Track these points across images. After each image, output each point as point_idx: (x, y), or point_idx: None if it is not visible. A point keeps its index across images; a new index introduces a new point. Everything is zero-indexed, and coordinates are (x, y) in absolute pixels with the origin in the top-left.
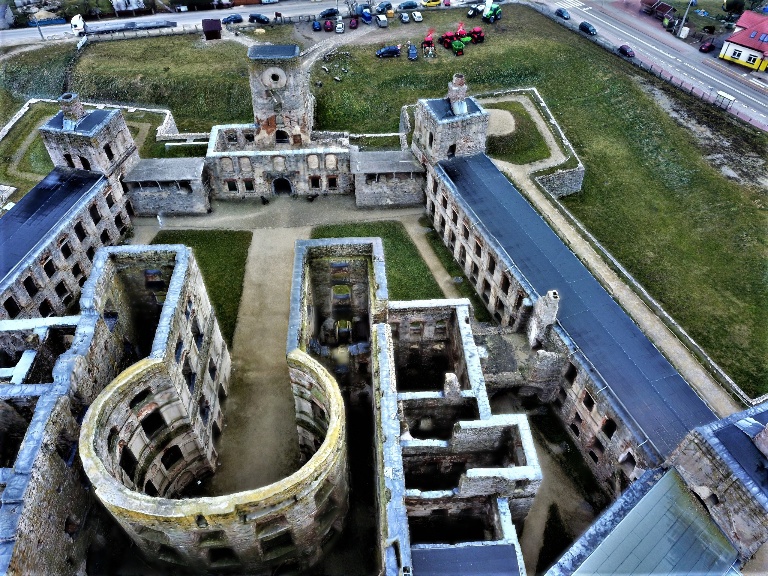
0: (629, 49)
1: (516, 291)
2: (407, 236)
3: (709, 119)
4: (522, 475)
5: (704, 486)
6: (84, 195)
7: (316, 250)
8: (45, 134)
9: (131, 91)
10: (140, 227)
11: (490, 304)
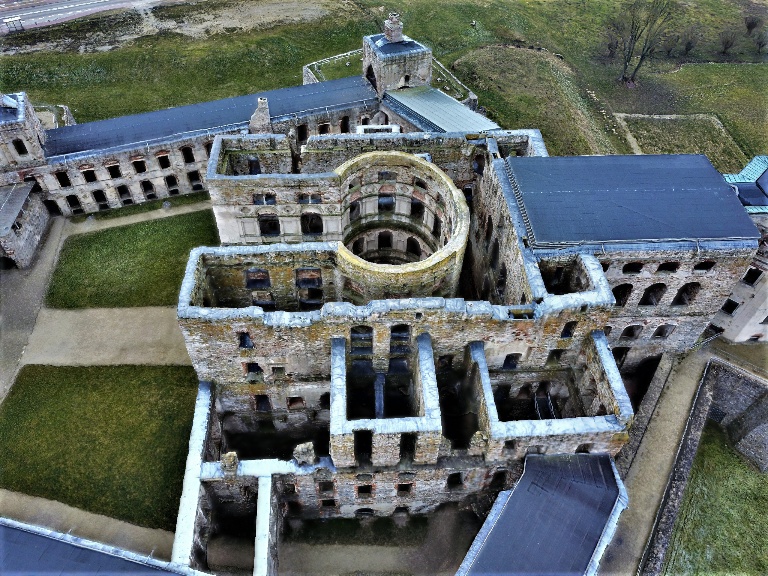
0: None
1: None
2: (94, 233)
3: (30, 39)
4: (398, 131)
5: (401, 79)
6: None
7: None
8: None
9: None
10: None
11: None
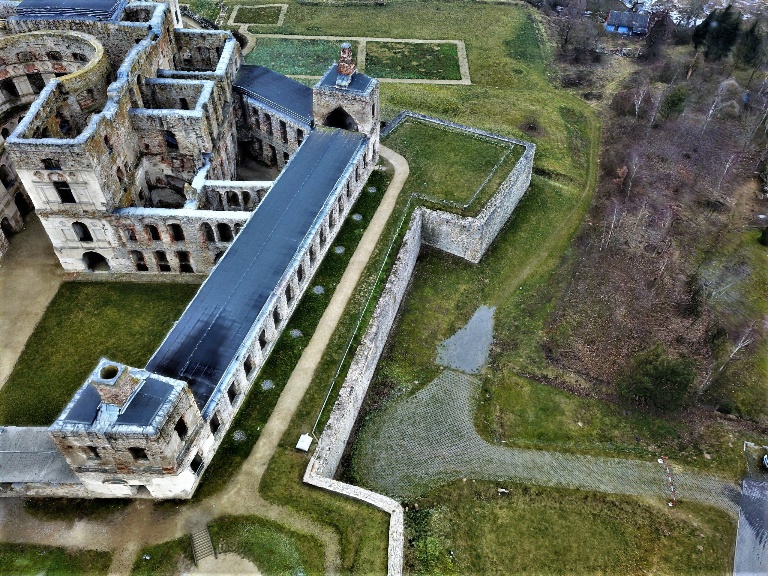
0: None
1: None
2: None
3: None
4: None
5: None
6: (155, 354)
7: None
8: None
9: None
10: None
11: None
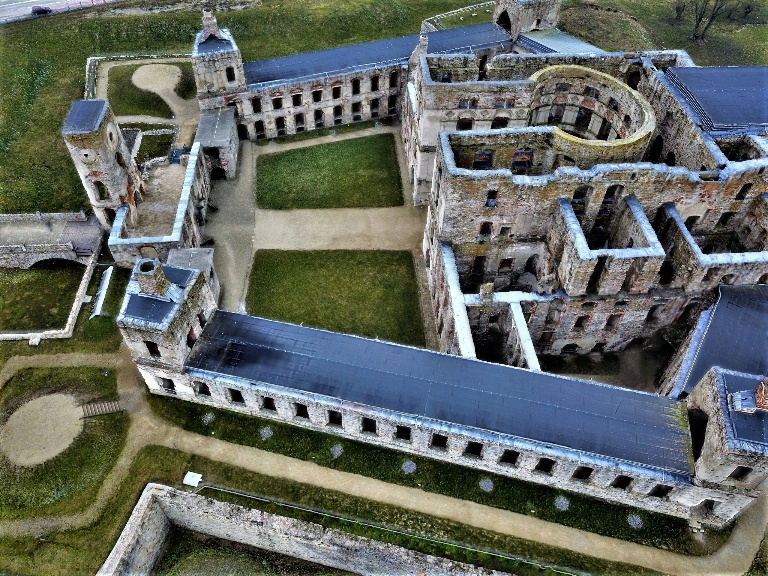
0: (41, 7)
1: (388, 75)
2: (279, 153)
3: (169, 0)
4: None
5: None
6: (257, 318)
7: None
8: (171, 330)
9: None
10: None
11: (365, 115)
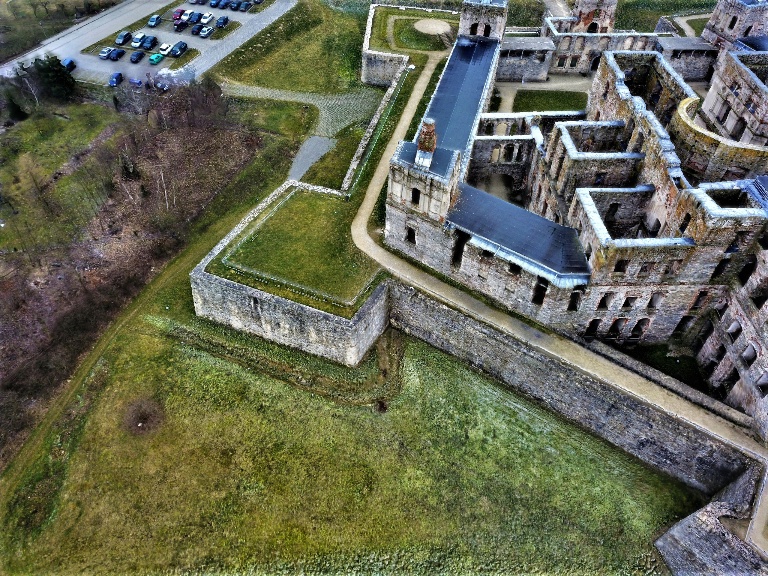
0: None
1: None
2: (702, 98)
3: None
4: None
5: None
6: None
7: (741, 58)
8: (466, 7)
9: (428, 6)
10: (502, 87)
11: None
